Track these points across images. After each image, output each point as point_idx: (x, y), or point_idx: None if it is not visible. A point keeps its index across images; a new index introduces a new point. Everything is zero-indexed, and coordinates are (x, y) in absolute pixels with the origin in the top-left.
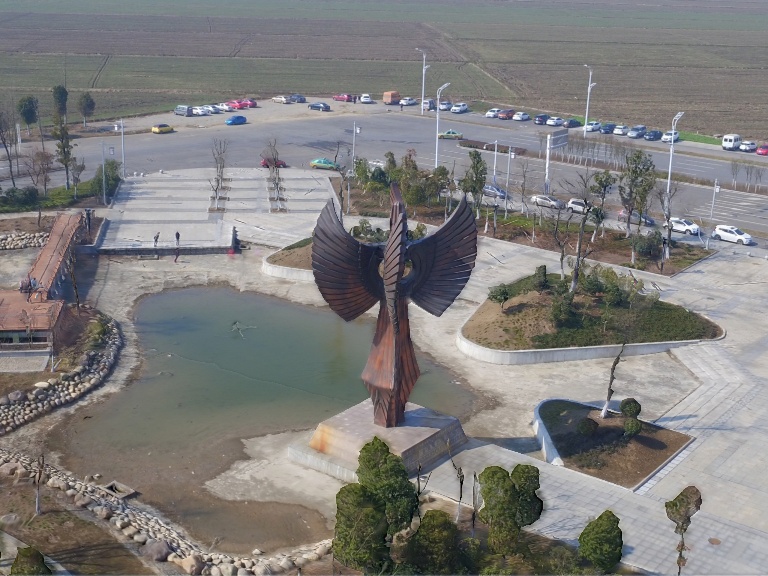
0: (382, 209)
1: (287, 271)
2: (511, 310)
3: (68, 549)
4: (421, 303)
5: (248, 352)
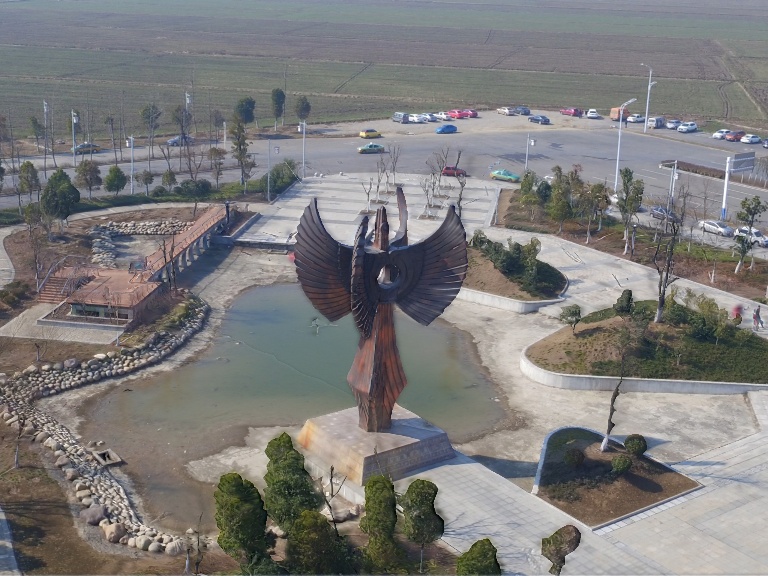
0: (531, 223)
1: None
2: (583, 333)
3: (20, 501)
4: (408, 310)
5: (314, 348)
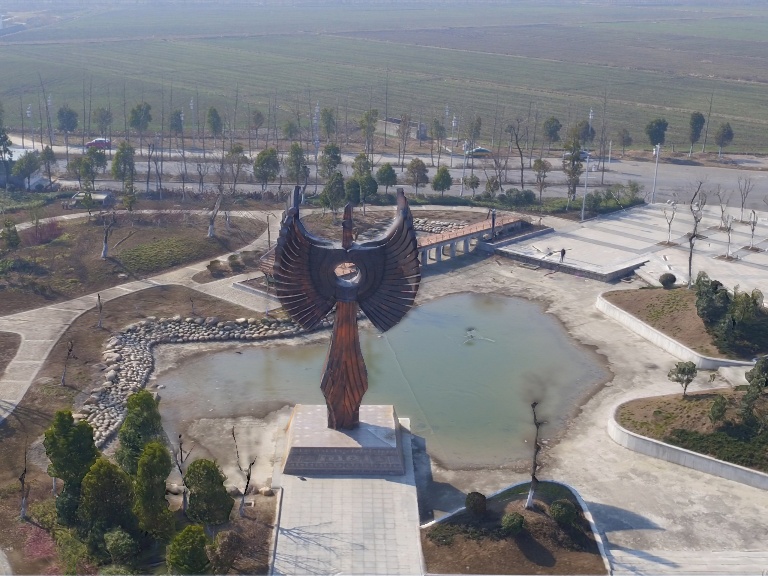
0: None
1: (607, 306)
2: (695, 396)
3: (30, 409)
4: (369, 313)
5: (445, 356)
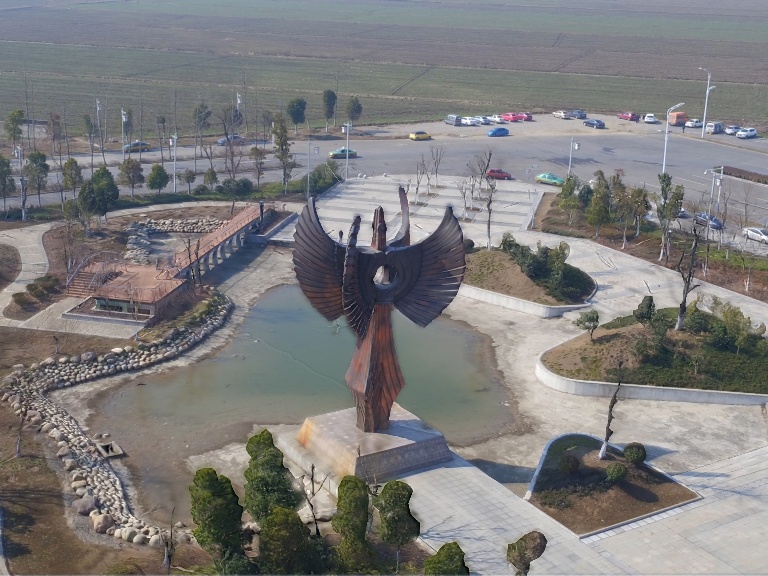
0: (569, 227)
1: None
2: (601, 339)
3: (15, 489)
4: (405, 311)
5: (331, 348)
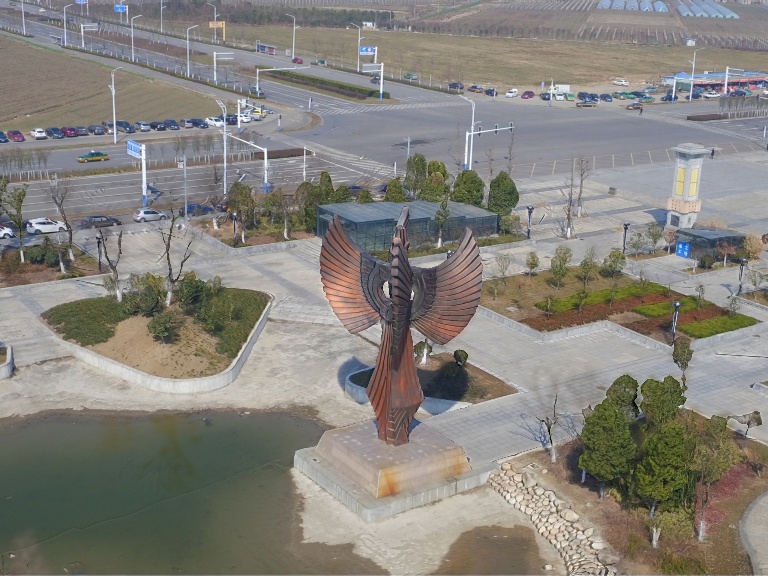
0: None
1: None
2: (167, 338)
3: None
4: None
5: (44, 505)
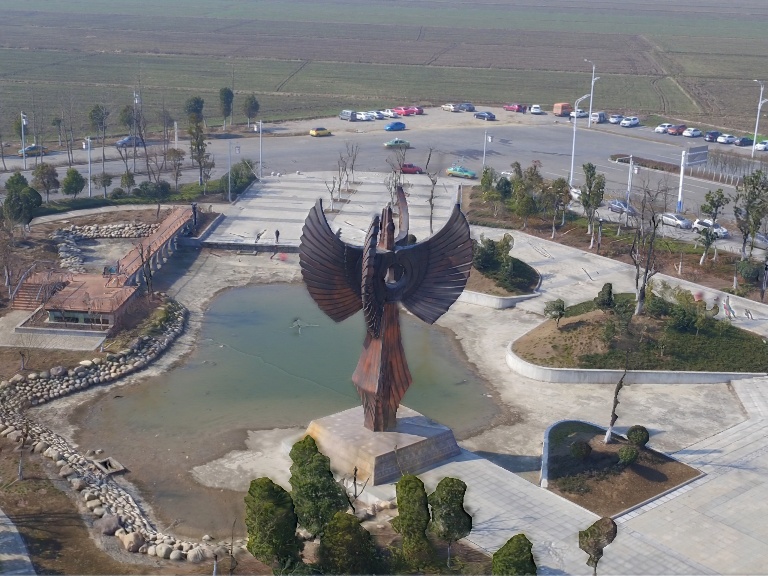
0: (495, 219)
1: None
2: (567, 327)
3: (30, 514)
4: (413, 309)
5: (299, 349)
